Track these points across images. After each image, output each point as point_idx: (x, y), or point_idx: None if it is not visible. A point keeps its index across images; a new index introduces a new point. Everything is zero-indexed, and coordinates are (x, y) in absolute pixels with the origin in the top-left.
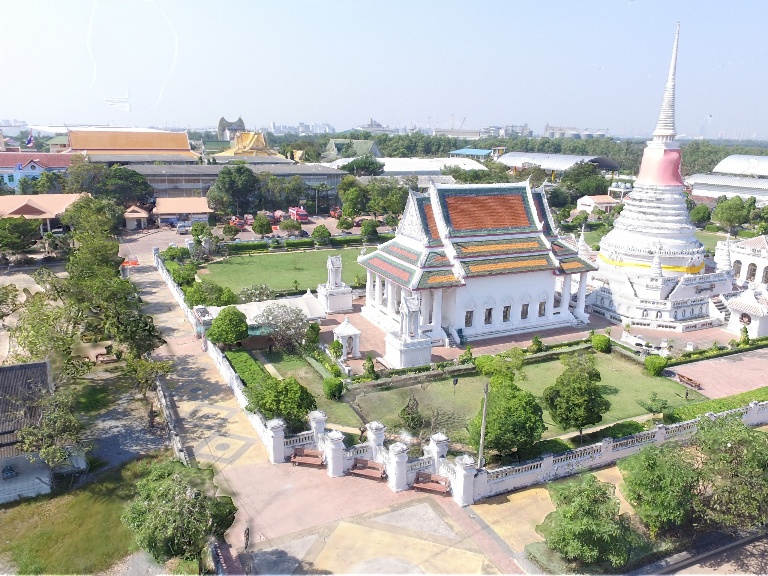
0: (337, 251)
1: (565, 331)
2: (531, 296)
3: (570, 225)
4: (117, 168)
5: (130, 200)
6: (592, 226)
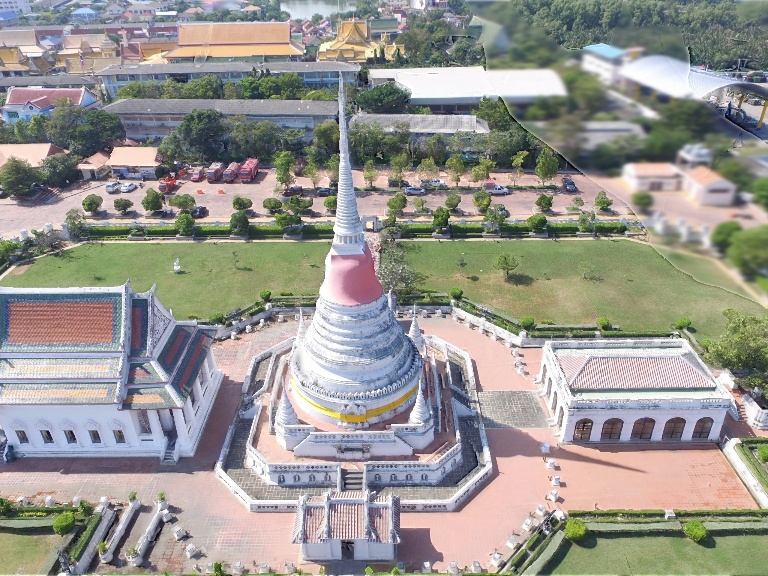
0: (189, 246)
1: (139, 466)
2: (99, 423)
3: (519, 227)
4: (93, 111)
5: (96, 147)
6: (556, 230)
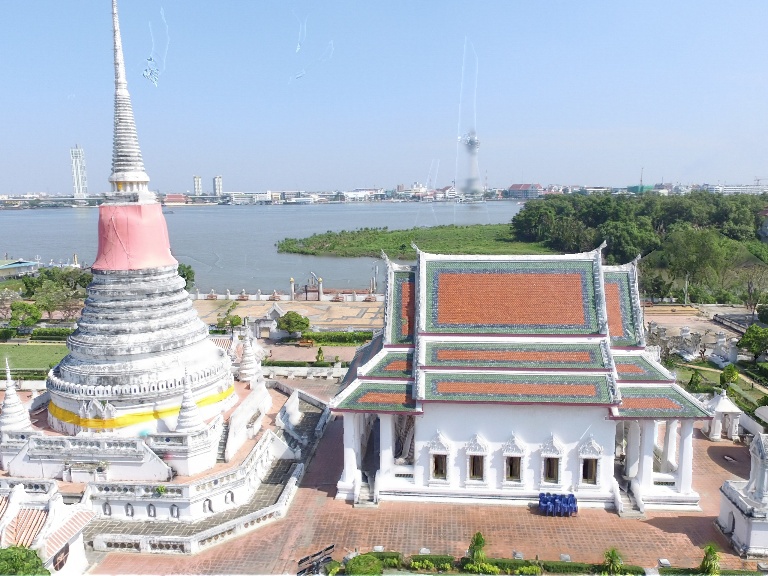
0: None
1: None
2: None
3: None
4: None
5: None
6: None
